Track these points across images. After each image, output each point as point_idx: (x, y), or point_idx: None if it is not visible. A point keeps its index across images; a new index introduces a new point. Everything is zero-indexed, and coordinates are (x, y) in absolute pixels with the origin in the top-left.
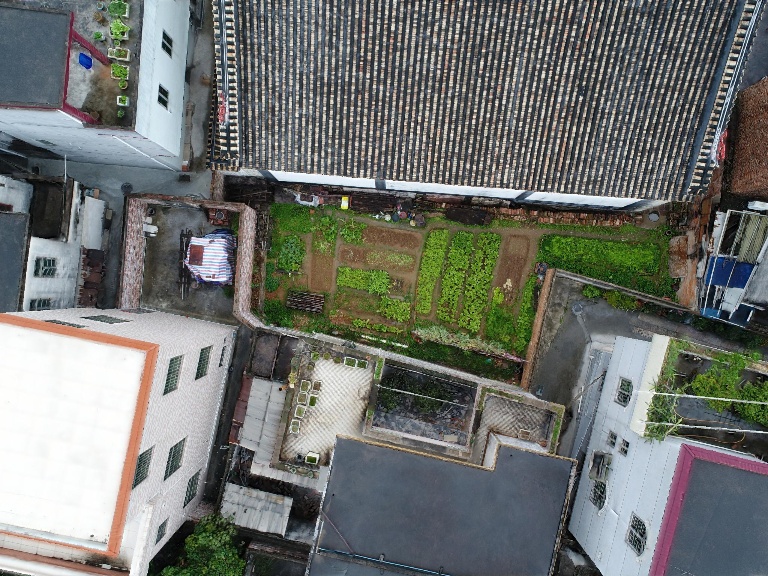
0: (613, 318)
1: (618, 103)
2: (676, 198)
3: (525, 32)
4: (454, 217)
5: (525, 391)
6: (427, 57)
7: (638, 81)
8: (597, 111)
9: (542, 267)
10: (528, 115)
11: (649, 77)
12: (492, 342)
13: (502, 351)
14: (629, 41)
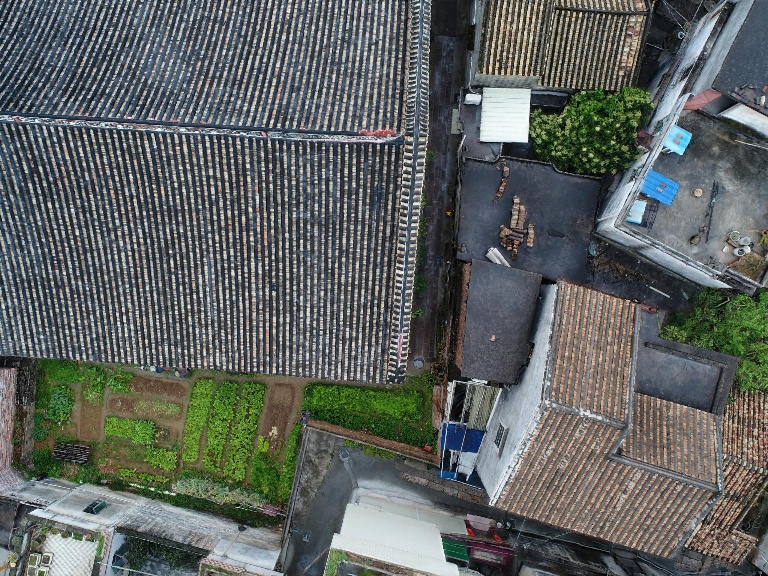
0: (379, 464)
1: (310, 298)
2: (384, 381)
3: (205, 237)
4: None
5: (278, 546)
6: (117, 257)
7: (324, 280)
8: (292, 305)
9: (305, 416)
10: (227, 307)
11: (334, 276)
12: (252, 493)
13: (263, 502)
14: (306, 246)
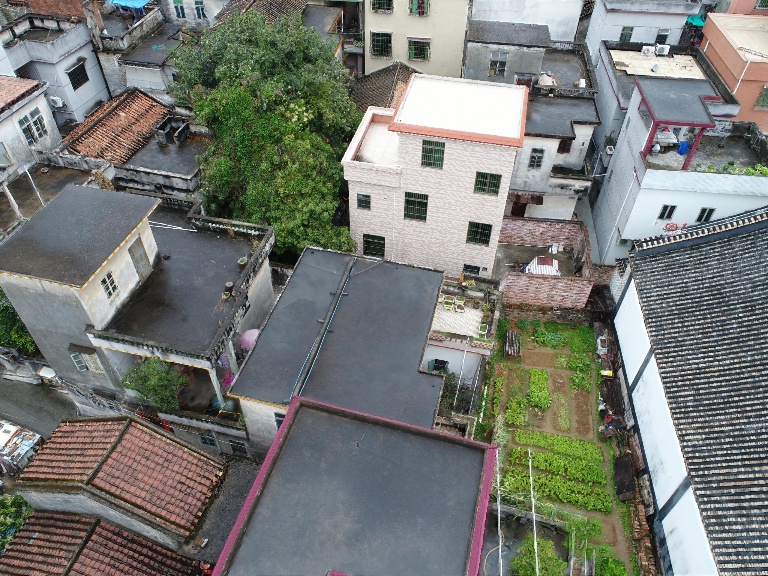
0: None
1: None
2: None
3: None
4: (619, 465)
5: None
6: None
7: None
8: None
9: None
10: (766, 442)
11: None
12: None
13: None
14: None
